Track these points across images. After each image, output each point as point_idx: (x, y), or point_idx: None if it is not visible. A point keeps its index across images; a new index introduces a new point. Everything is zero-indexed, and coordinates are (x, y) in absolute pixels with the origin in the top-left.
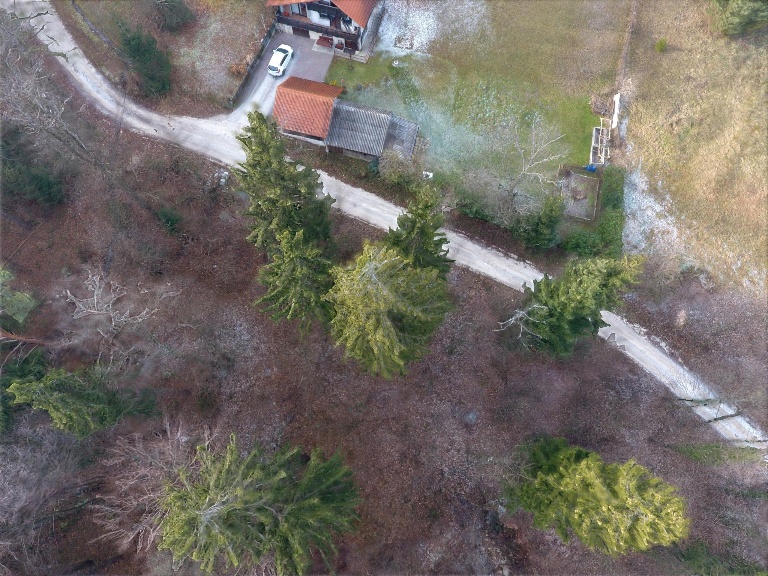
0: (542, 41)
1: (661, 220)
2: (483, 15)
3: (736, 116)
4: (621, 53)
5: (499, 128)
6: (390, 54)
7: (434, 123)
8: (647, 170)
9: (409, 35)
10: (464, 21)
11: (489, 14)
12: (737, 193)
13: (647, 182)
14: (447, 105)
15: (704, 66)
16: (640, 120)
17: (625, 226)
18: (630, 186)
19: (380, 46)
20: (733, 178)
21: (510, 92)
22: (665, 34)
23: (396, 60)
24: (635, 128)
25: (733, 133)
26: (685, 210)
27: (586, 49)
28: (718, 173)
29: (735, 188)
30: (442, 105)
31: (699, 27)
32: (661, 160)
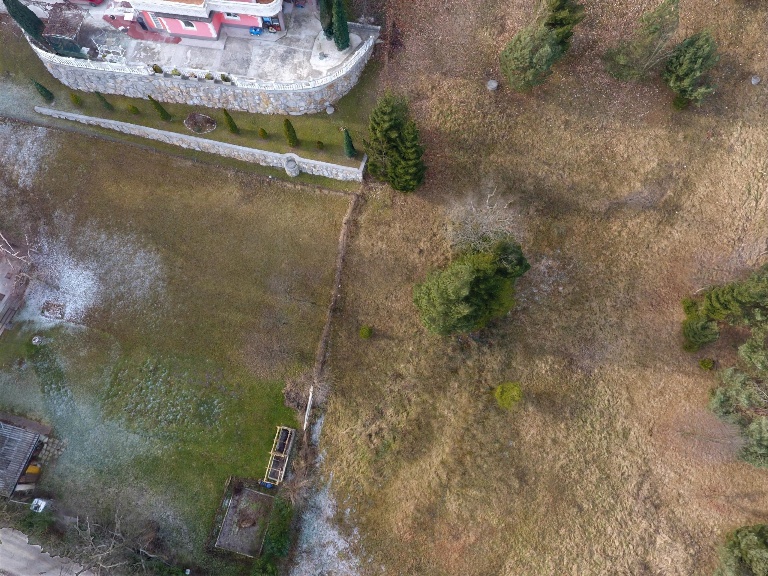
0: (230, 310)
1: (342, 562)
2: (157, 276)
3: (447, 432)
4: (322, 333)
5: (163, 423)
6: (33, 326)
7: (77, 418)
8: (336, 491)
9: (62, 300)
10: (132, 284)
11: (164, 275)
12: (437, 536)
13: (334, 507)
14: (99, 393)
15: (416, 362)
16: (337, 422)
17: (294, 570)
18: (314, 510)
19: (23, 314)
20: (434, 515)
21: (185, 373)
22: (373, 316)
23: (36, 336)
24: (330, 432)
25: (441, 455)
26: (374, 550)
27: (283, 323)
28: (417, 507)
29: (436, 528)
30: (92, 393)
31: (414, 311)
32: (354, 480)
